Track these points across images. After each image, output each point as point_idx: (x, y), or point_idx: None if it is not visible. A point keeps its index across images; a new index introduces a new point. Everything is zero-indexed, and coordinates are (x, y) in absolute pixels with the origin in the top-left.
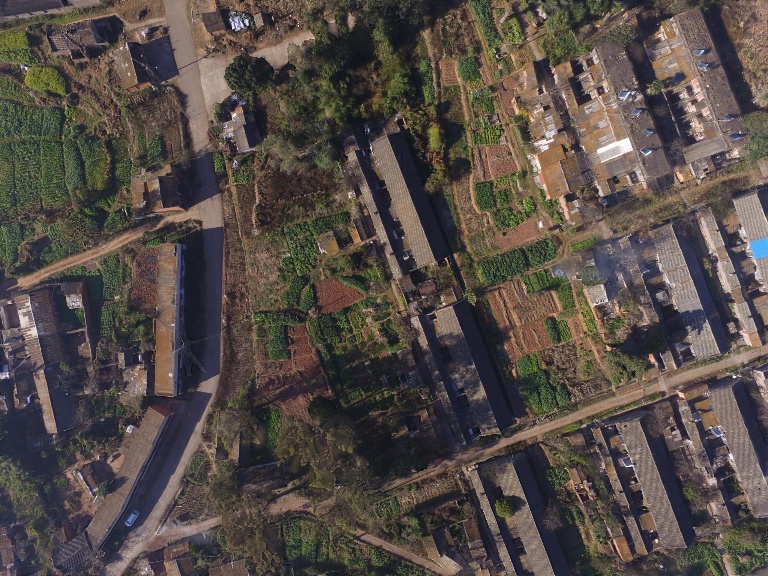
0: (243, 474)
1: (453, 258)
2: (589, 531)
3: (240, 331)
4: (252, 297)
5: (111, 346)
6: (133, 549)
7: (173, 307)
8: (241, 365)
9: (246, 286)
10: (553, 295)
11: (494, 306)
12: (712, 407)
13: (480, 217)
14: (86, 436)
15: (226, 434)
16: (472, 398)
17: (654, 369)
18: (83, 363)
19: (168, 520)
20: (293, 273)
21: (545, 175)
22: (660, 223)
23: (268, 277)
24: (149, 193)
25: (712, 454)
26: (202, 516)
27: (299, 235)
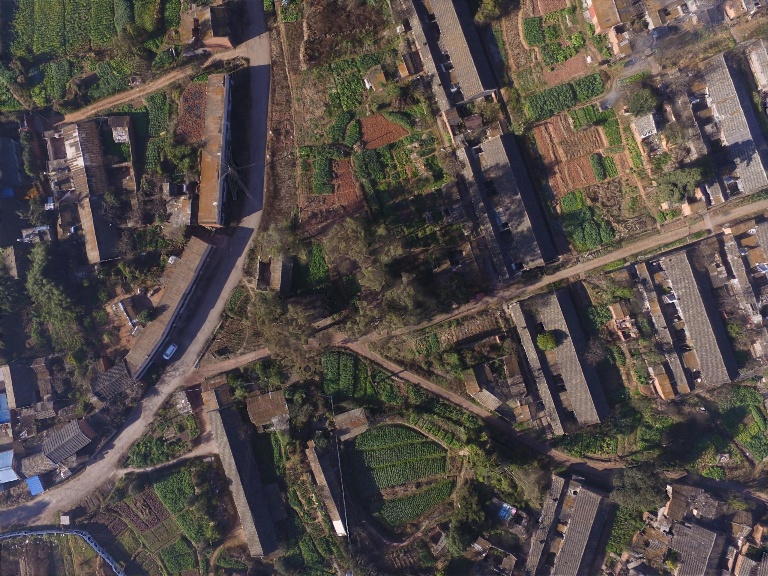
0: (284, 303)
1: (500, 94)
2: (630, 372)
3: (284, 168)
4: (297, 132)
5: (156, 177)
6: (170, 383)
7: (220, 136)
8: (284, 201)
9: (291, 123)
10: (599, 131)
11: (540, 141)
12: (759, 243)
13: (528, 53)
14: (129, 263)
15: (275, 237)
16: (516, 230)
17: (701, 203)
18: (127, 195)
19: (206, 355)
20: (339, 108)
21: (596, 6)
22: (710, 55)
23: (314, 112)
24: (200, 24)
25: (757, 292)
26: (240, 350)
27: (346, 71)
